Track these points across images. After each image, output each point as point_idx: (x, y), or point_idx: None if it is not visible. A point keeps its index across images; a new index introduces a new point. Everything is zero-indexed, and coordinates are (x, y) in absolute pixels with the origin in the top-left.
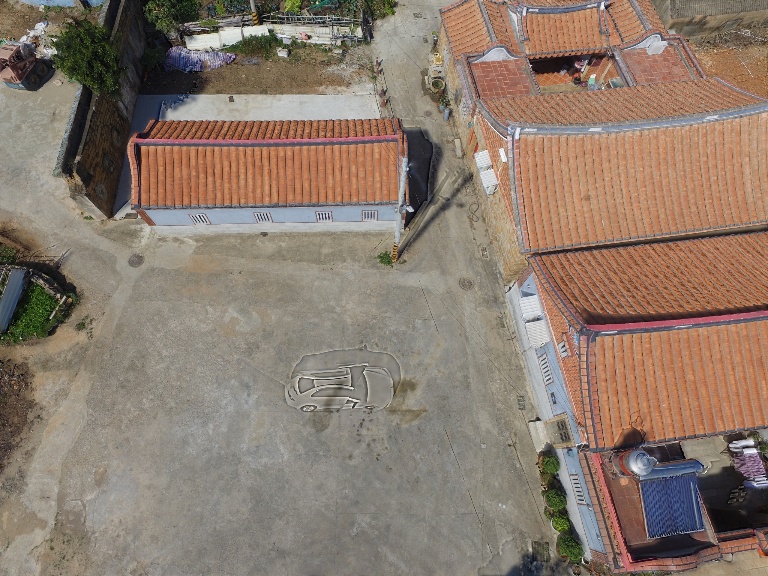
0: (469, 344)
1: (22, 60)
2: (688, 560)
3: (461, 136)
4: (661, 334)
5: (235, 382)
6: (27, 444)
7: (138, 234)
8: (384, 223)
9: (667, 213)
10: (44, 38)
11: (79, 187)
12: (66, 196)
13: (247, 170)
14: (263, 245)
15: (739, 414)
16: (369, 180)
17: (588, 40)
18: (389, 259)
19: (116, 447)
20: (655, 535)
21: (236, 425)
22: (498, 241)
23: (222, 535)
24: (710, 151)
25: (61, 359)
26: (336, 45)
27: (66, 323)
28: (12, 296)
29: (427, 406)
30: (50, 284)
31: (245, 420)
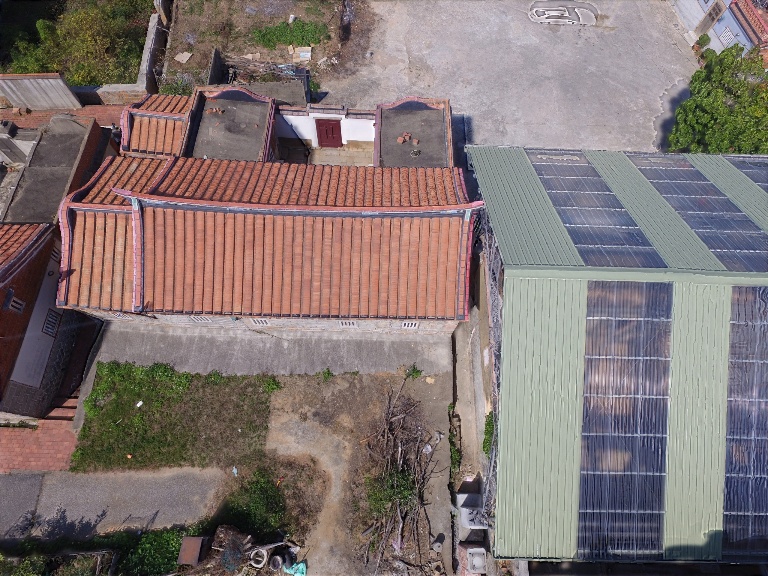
0: (638, 2)
1: None
2: None
3: None
4: None
5: (496, 10)
6: (380, 29)
7: None
8: None
9: None
10: None
11: None
12: None
13: None
14: None
15: None
16: None
17: None
18: None
19: (433, 33)
20: None
21: (503, 28)
22: None
23: (510, 70)
24: None
25: None
26: None
27: None
28: None
29: (618, 26)
30: None
31: (508, 26)
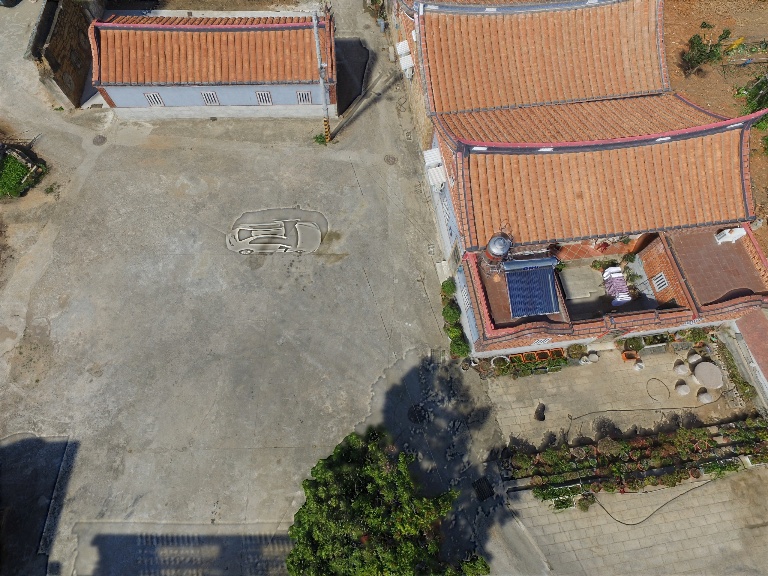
0: (389, 205)
1: None
2: (538, 324)
3: (394, 44)
4: (528, 158)
5: (183, 232)
6: (0, 276)
7: (102, 120)
8: (319, 108)
9: (556, 85)
10: None
11: (48, 72)
12: (39, 92)
13: (194, 52)
14: (212, 128)
15: (593, 224)
16: (301, 62)
17: None
18: (323, 139)
19: (78, 280)
20: (518, 315)
21: (182, 264)
22: (418, 122)
23: (167, 344)
24: (593, 32)
25: (31, 214)
26: None
27: (36, 188)
28: None
29: (349, 251)
30: (23, 157)
31: (190, 260)
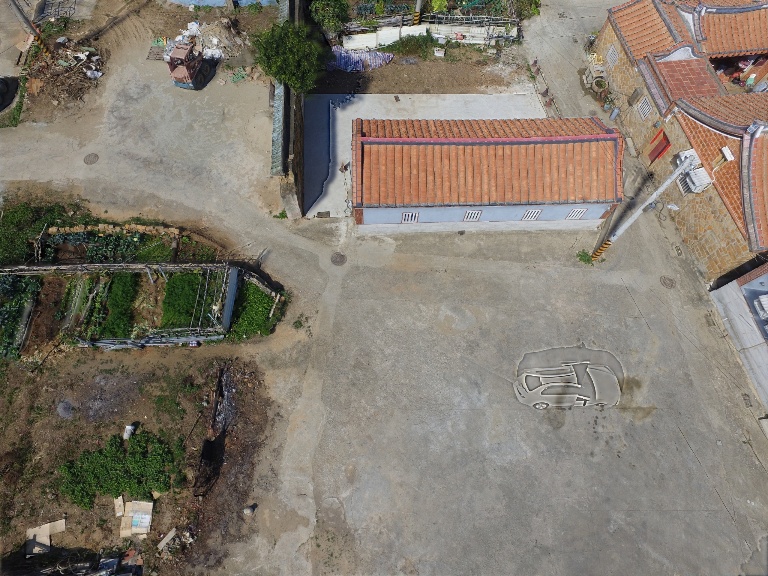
0: (683, 342)
1: (193, 59)
2: None
3: (633, 135)
4: None
5: (463, 380)
6: (273, 442)
7: (335, 233)
8: (584, 222)
9: None
10: (202, 38)
11: (290, 186)
12: (251, 195)
13: (466, 169)
14: (462, 243)
15: None
16: (586, 179)
17: (762, 40)
18: (589, 257)
19: (360, 444)
20: None
21: (474, 422)
22: (699, 239)
23: (483, 532)
24: None
25: (287, 357)
26: (490, 45)
27: (283, 321)
28: (231, 294)
29: (656, 403)
30: (261, 282)
31: (481, 417)
